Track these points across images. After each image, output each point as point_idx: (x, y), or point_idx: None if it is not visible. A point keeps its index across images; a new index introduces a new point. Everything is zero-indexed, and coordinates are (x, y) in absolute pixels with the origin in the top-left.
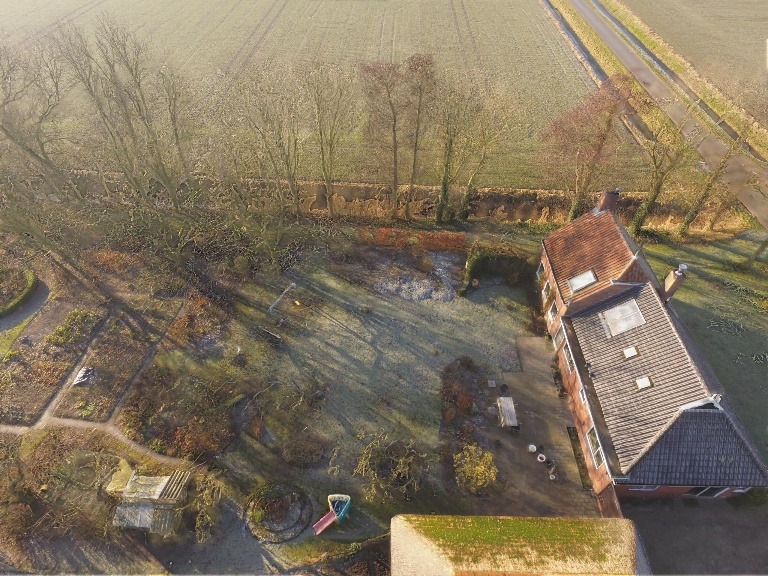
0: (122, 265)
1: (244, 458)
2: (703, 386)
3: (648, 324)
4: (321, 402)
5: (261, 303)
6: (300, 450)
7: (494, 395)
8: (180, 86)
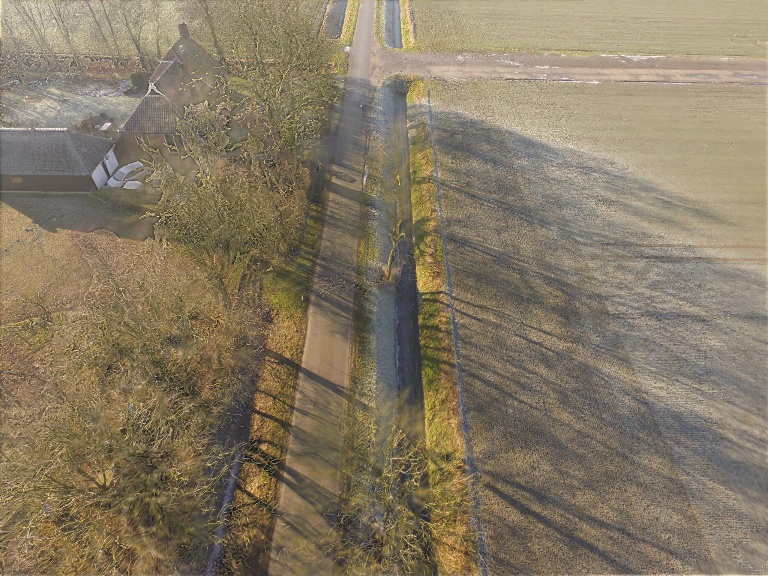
0: None
1: None
2: None
3: None
4: None
5: (7, 98)
6: None
7: None
8: None
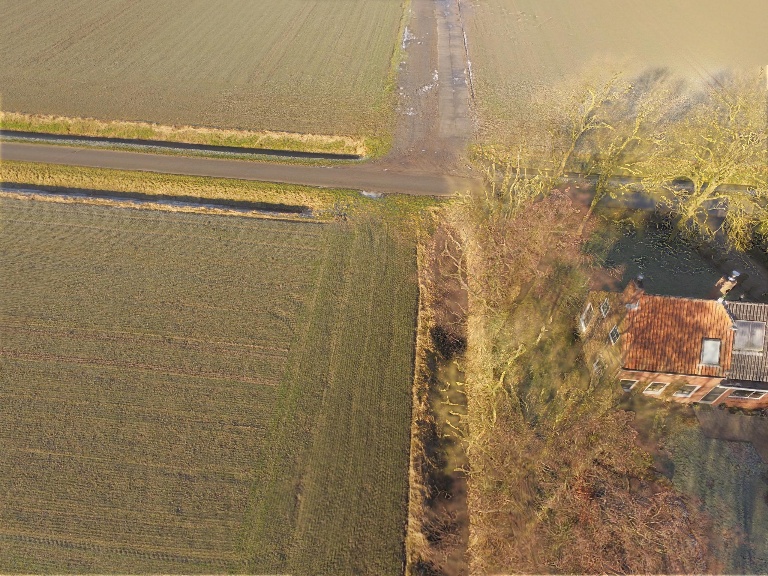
0: None
1: None
2: None
3: (767, 321)
4: None
5: None
6: None
7: None
8: None
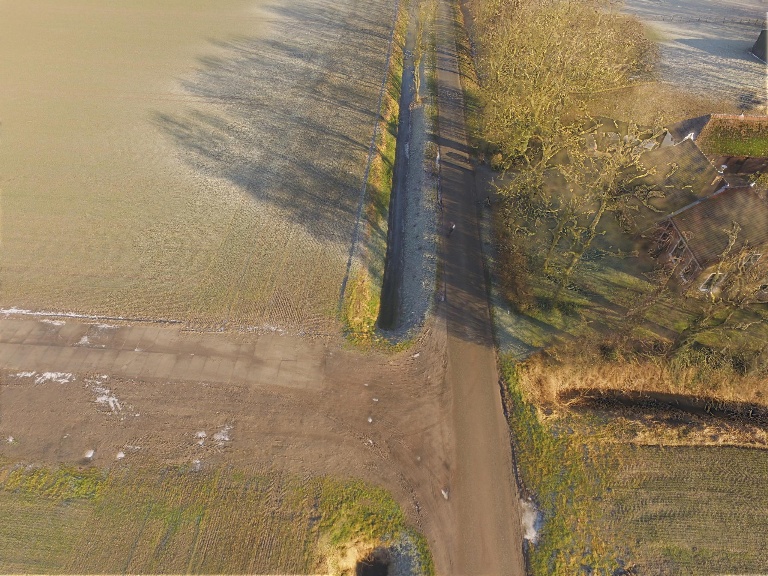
0: None
1: None
2: None
3: None
4: None
5: None
6: None
7: None
8: None
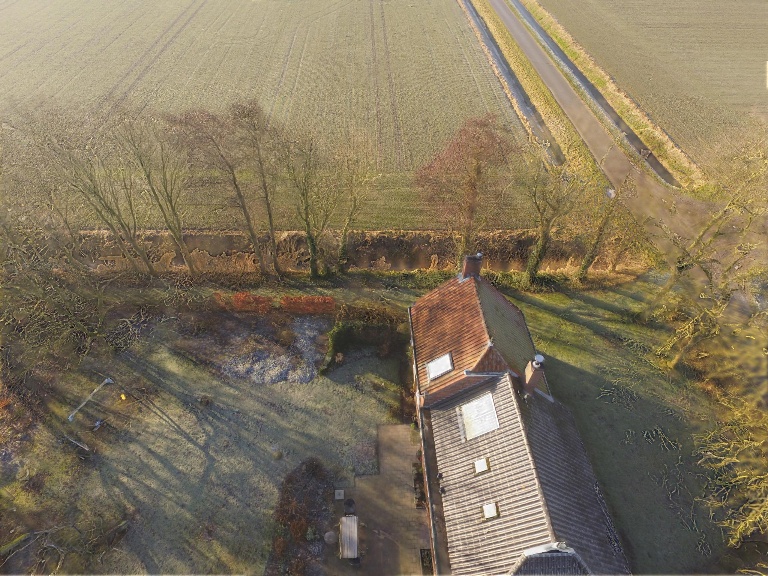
0: None
1: None
2: (547, 526)
3: (501, 429)
4: (125, 537)
5: (80, 399)
6: None
7: (340, 510)
8: None
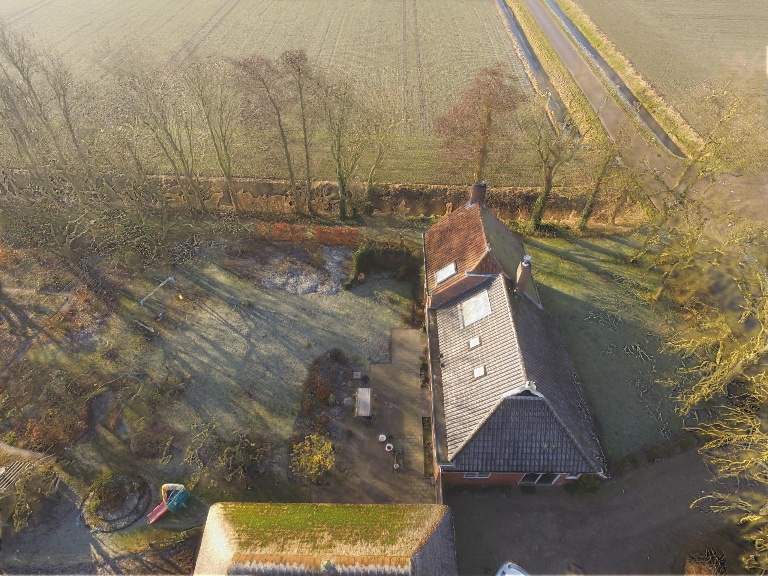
0: (15, 261)
1: (94, 449)
2: (523, 374)
3: (493, 314)
4: (183, 394)
5: None
6: (147, 441)
7: (357, 386)
8: (68, 82)
